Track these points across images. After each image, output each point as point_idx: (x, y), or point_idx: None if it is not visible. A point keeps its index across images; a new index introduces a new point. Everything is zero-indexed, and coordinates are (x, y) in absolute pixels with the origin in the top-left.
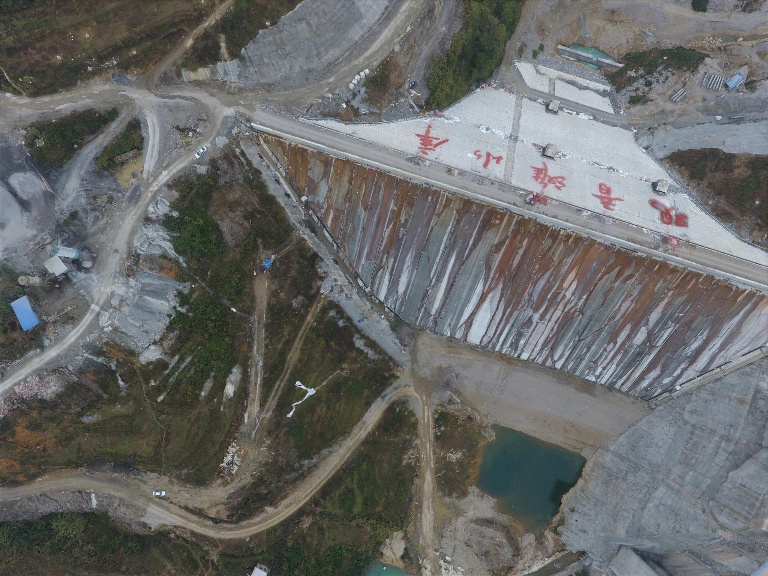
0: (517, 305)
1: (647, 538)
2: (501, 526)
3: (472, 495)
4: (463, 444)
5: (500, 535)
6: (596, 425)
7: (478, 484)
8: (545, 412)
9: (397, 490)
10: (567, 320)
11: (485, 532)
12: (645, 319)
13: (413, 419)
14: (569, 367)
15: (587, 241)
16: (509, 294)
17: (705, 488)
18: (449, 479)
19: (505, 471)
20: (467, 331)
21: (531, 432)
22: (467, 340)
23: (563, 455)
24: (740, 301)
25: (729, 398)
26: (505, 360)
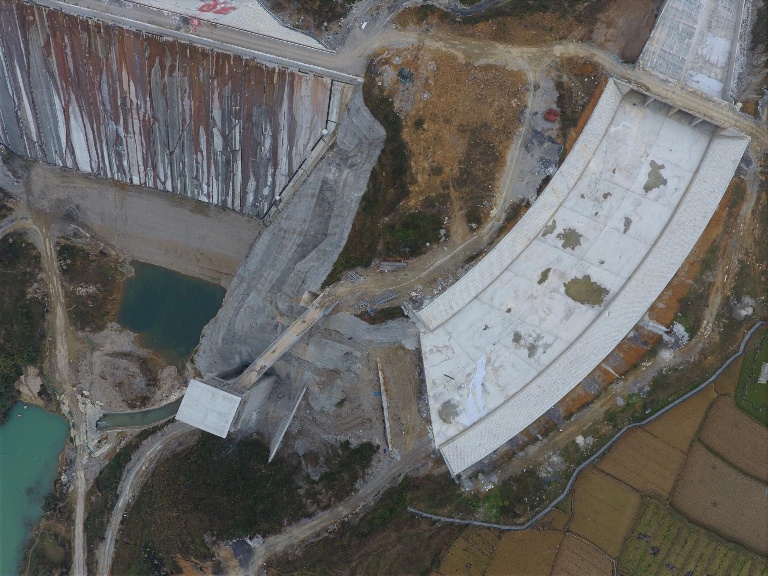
0: (98, 118)
1: (237, 342)
2: (137, 358)
3: (109, 330)
4: (96, 279)
5: (133, 365)
6: (221, 250)
7: (120, 320)
8: (172, 240)
9: (20, 323)
10: (148, 130)
11: (118, 363)
12: (211, 118)
13: (34, 252)
14: (179, 188)
15: (116, 30)
16: (85, 106)
17: (275, 281)
18: (80, 313)
19: (150, 308)
20: (74, 157)
21: (168, 265)
22: (79, 168)
23: (205, 288)
24: (277, 83)
25: (306, 196)
26: (118, 186)
